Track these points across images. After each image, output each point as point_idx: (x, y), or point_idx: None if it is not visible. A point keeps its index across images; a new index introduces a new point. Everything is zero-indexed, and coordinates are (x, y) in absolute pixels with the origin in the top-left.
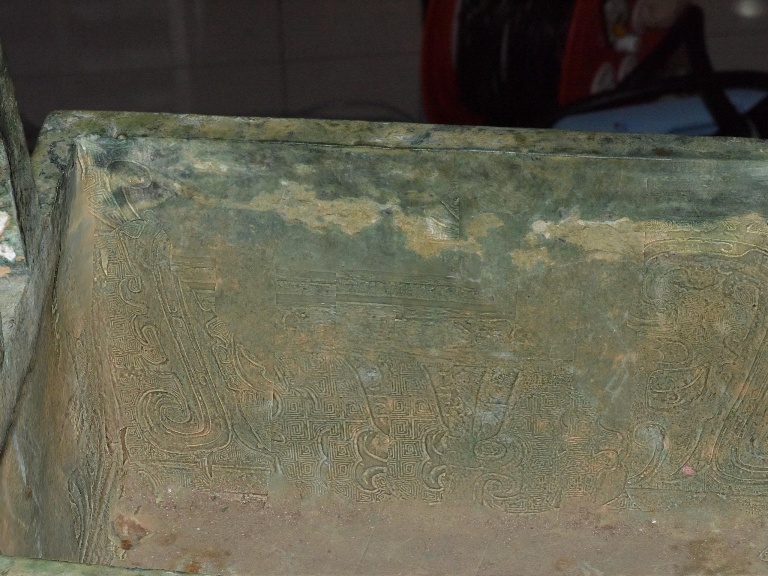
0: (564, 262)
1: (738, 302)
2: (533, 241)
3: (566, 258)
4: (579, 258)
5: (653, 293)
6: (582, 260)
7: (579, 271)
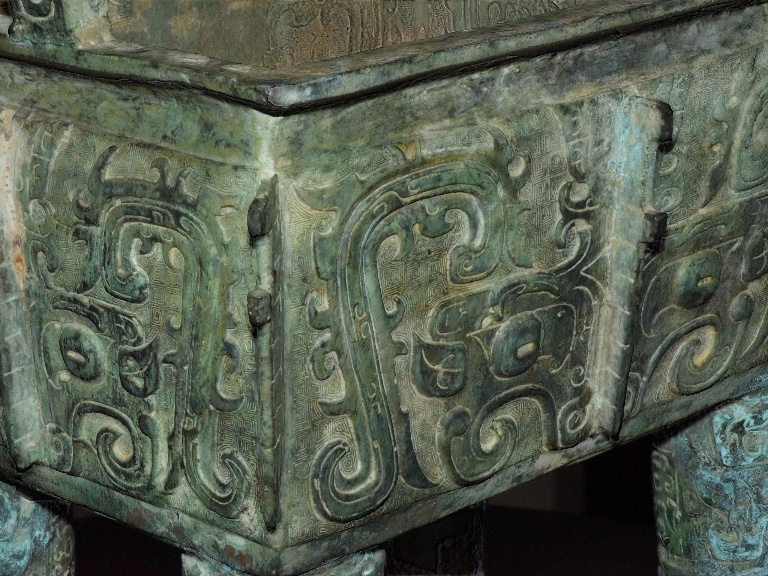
0: (211, 21)
1: (336, 29)
2: (187, 3)
3: (212, 16)
4: (222, 13)
5: (272, 41)
6: (224, 15)
7: (223, 28)
